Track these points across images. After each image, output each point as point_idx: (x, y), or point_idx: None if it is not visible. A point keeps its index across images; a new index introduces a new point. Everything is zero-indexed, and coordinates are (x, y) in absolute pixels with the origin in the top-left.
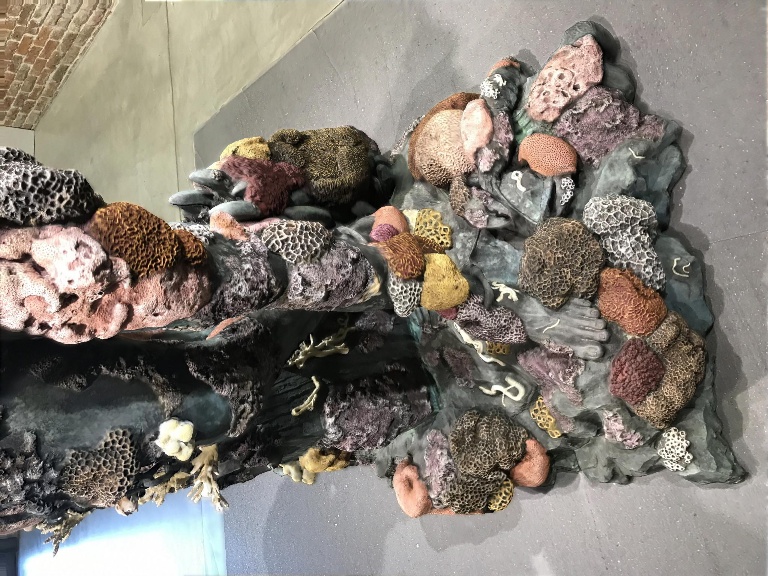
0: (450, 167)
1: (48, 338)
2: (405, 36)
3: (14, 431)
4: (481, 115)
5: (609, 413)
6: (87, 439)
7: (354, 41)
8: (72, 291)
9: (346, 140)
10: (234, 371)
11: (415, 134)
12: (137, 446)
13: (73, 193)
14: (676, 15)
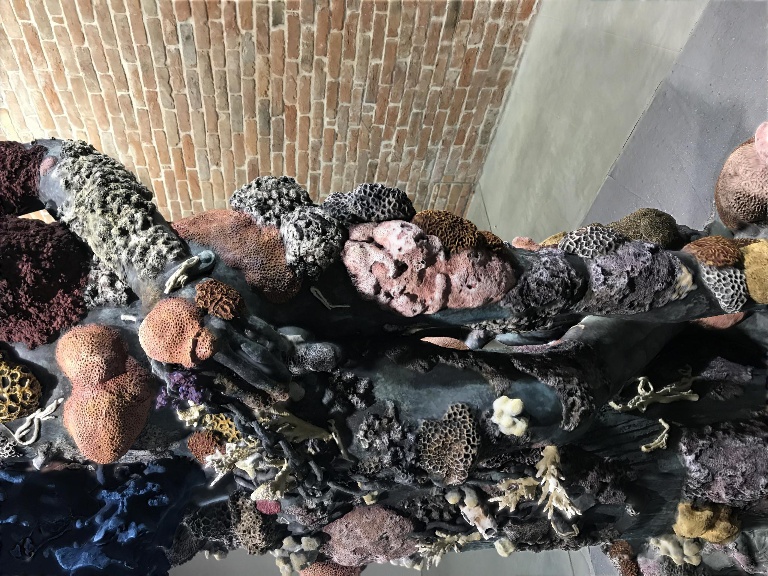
0: (760, 192)
1: (397, 336)
2: (692, 133)
3: (378, 400)
4: None
5: None
6: (434, 412)
7: (647, 163)
8: (402, 258)
9: (647, 216)
10: (557, 369)
11: (717, 187)
12: (476, 420)
13: (397, 198)
14: None
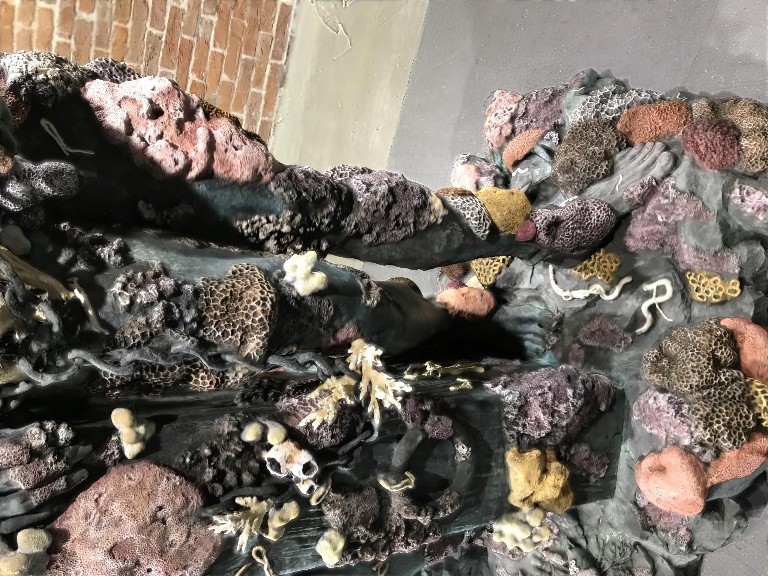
0: None
1: None
2: None
3: (138, 261)
4: (462, 166)
5: (735, 192)
6: (213, 273)
7: None
8: (156, 99)
9: None
10: None
11: None
12: None
13: None
14: (539, 53)
